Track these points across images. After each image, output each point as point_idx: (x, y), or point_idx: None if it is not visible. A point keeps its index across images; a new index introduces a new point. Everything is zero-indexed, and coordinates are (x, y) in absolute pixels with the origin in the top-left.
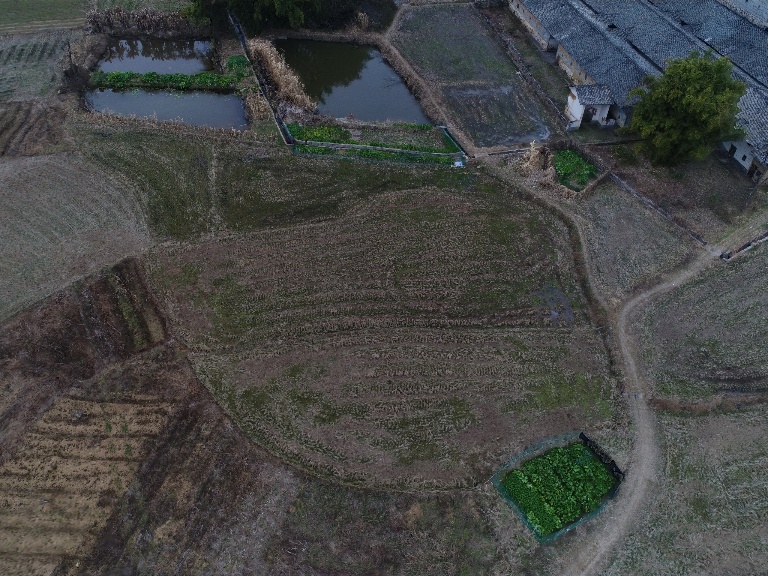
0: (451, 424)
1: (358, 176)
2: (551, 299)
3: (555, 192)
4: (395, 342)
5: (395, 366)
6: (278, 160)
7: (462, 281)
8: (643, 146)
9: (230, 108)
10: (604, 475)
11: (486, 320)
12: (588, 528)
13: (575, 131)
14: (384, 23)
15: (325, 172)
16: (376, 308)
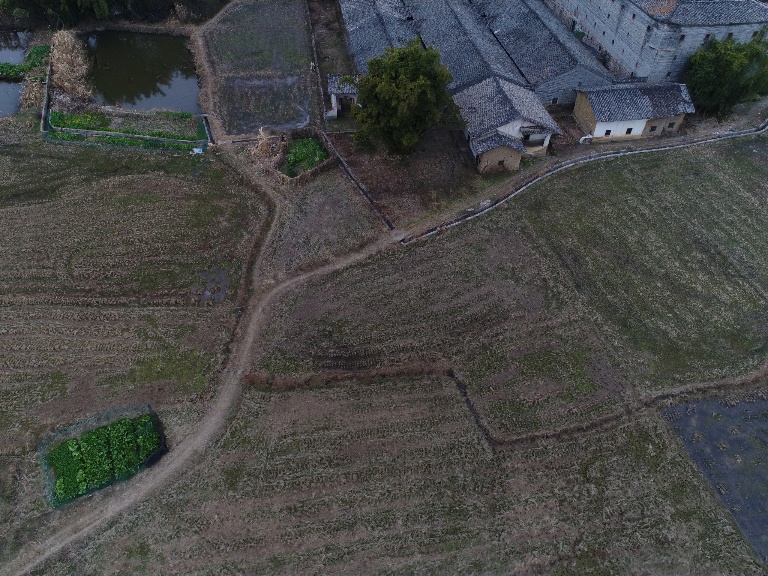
0: (39, 396)
1: (94, 162)
2: (212, 280)
3: (273, 178)
4: (31, 319)
5: (18, 341)
6: (25, 146)
7: (134, 262)
8: (360, 133)
9: (9, 96)
10: (152, 445)
11: (134, 299)
12: (106, 494)
13: (333, 120)
14: (205, 15)
15: (64, 158)
16: (33, 287)
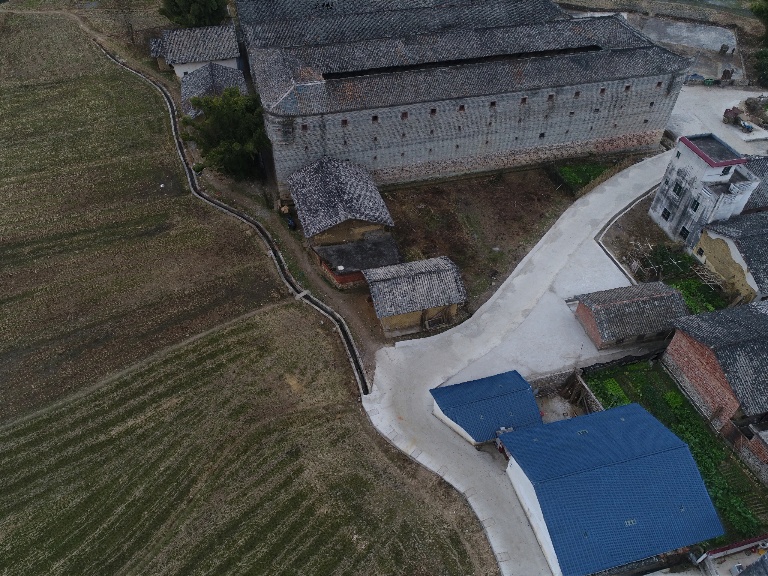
0: None
1: None
2: (90, 4)
3: None
4: None
5: None
6: None
7: None
8: None
9: None
10: None
11: None
12: None
13: None
14: None
15: None
16: None
